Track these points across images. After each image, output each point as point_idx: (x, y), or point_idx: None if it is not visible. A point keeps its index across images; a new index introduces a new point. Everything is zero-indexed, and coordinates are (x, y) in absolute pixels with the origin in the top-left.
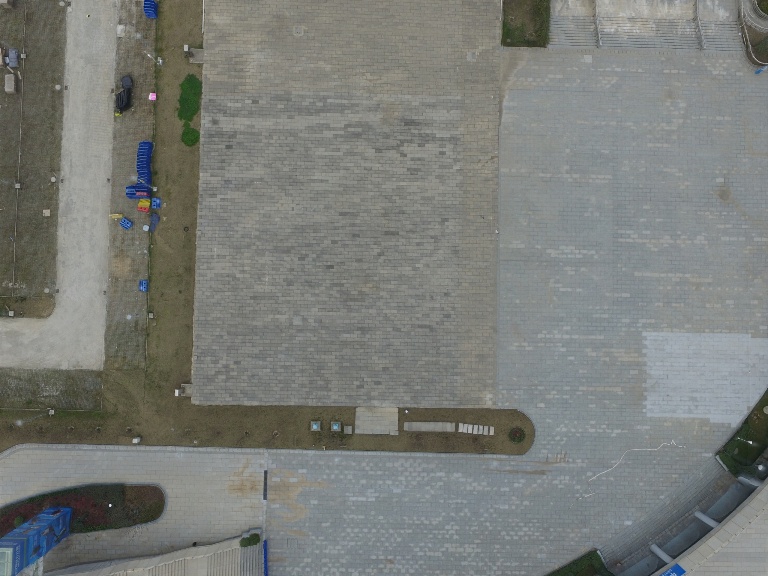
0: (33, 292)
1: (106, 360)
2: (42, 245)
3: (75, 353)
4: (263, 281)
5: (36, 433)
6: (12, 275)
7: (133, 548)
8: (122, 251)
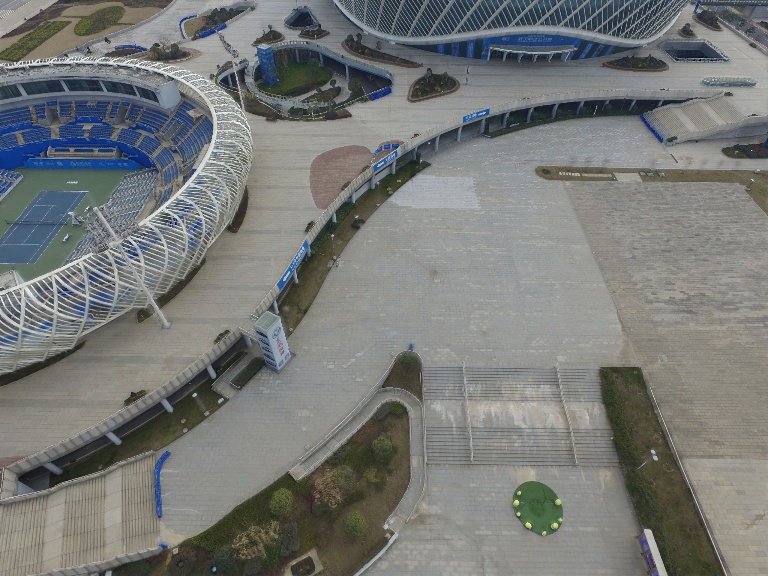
0: None
1: None
2: None
3: None
4: (736, 229)
5: None
6: None
7: (727, 141)
8: None
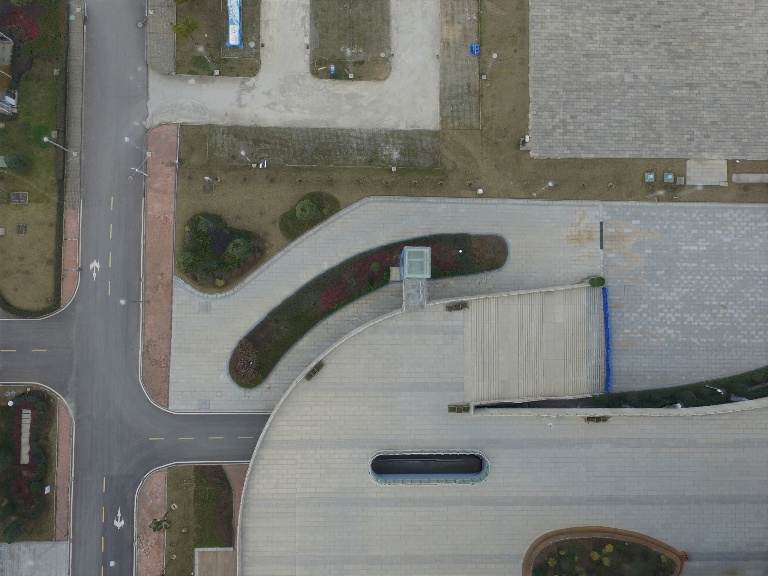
0: (370, 56)
1: (442, 120)
2: (376, 12)
3: (412, 114)
4: (595, 40)
5: (383, 187)
6: (349, 40)
7: None
8: (452, 17)
